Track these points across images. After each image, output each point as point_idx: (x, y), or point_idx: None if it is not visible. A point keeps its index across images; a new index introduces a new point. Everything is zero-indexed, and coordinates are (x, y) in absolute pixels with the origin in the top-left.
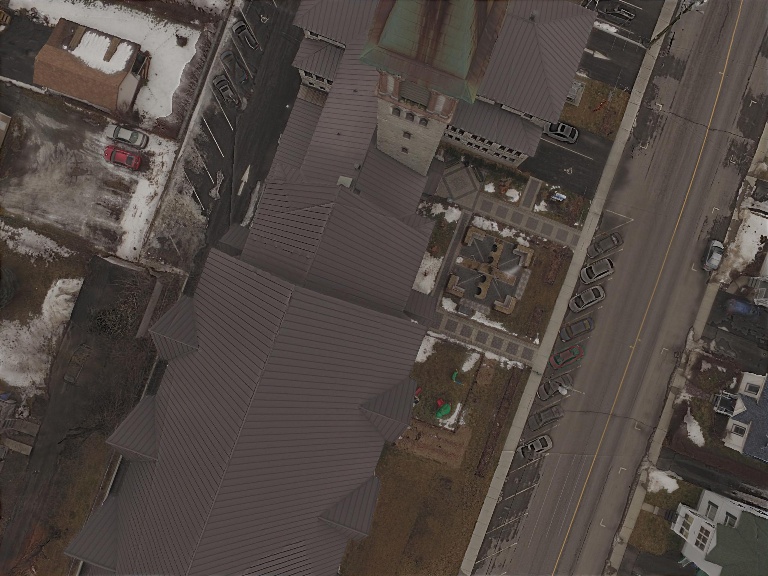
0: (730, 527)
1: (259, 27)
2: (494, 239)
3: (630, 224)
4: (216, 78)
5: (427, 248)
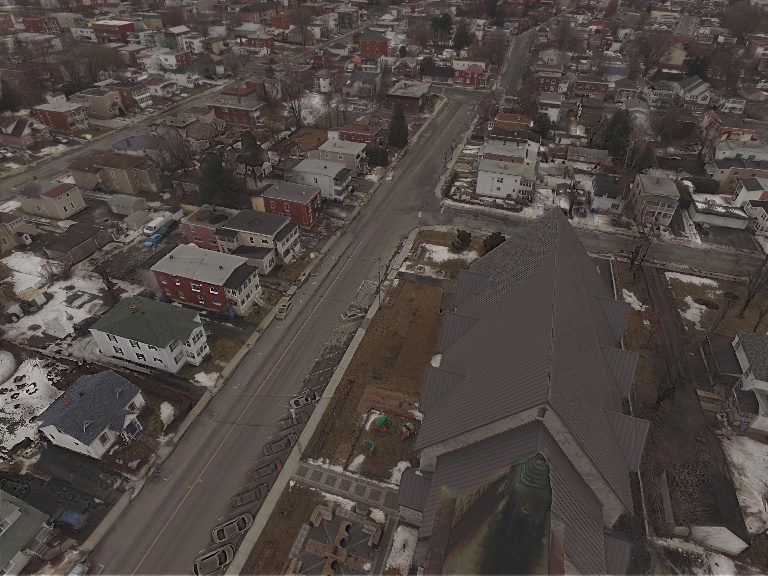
0: None
1: None
2: None
3: None
4: None
5: None
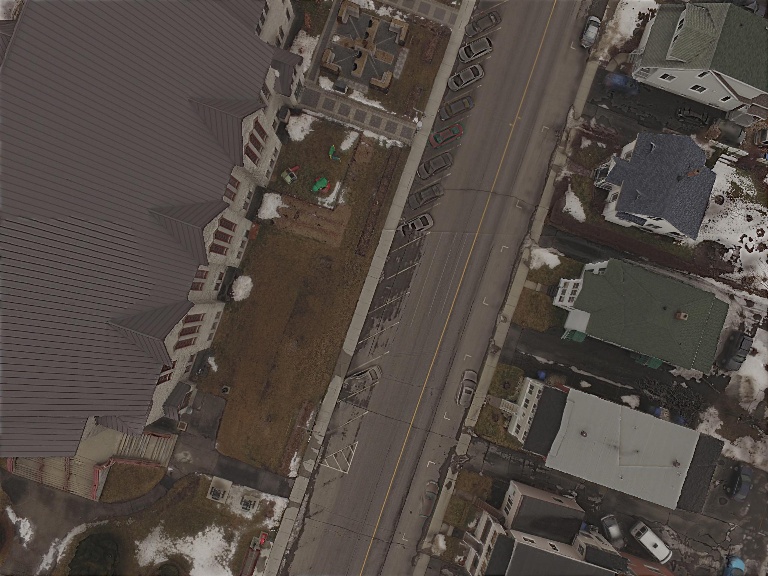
0: None
1: None
2: None
3: (508, 3)
4: None
5: (303, 26)
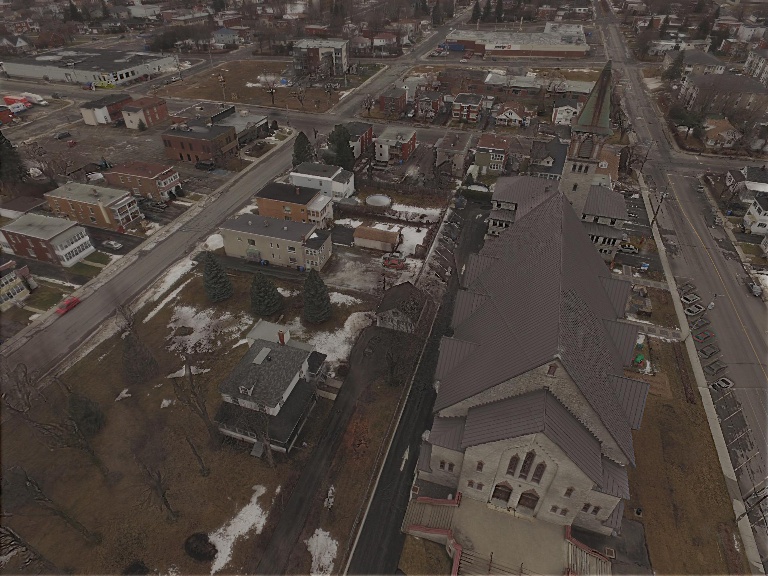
0: None
1: None
2: None
3: (694, 280)
4: None
5: None
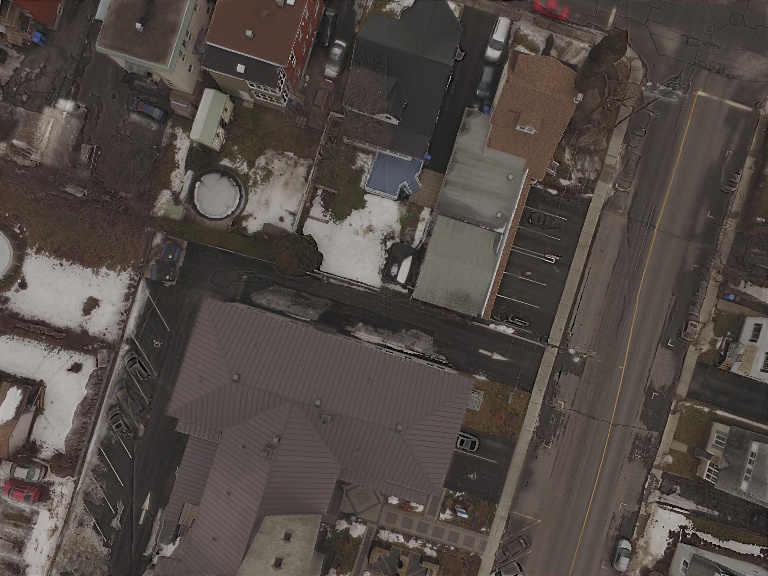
0: None
1: (152, 352)
2: (400, 551)
3: (537, 525)
4: (110, 411)
5: (333, 565)
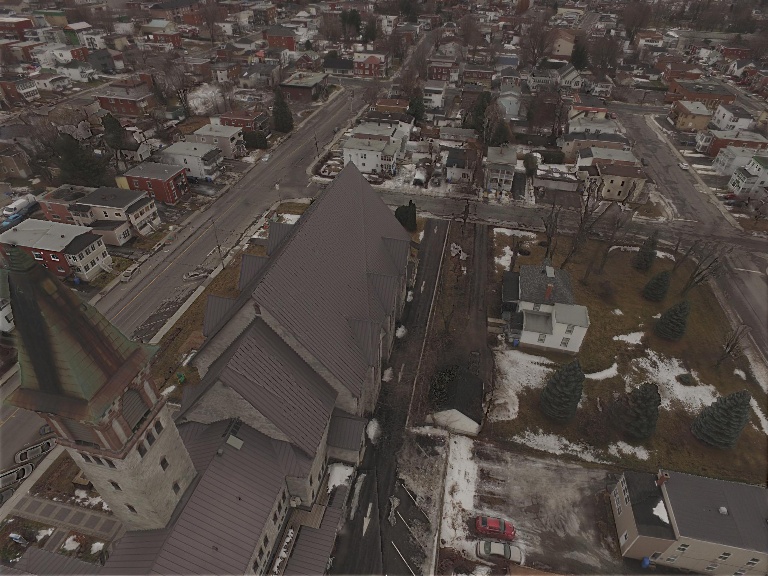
0: (5, 298)
1: None
2: None
3: None
4: None
5: None
